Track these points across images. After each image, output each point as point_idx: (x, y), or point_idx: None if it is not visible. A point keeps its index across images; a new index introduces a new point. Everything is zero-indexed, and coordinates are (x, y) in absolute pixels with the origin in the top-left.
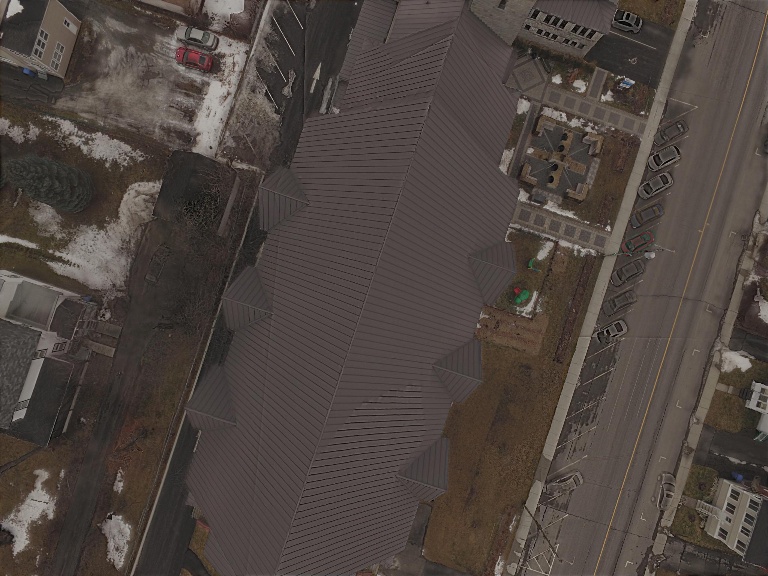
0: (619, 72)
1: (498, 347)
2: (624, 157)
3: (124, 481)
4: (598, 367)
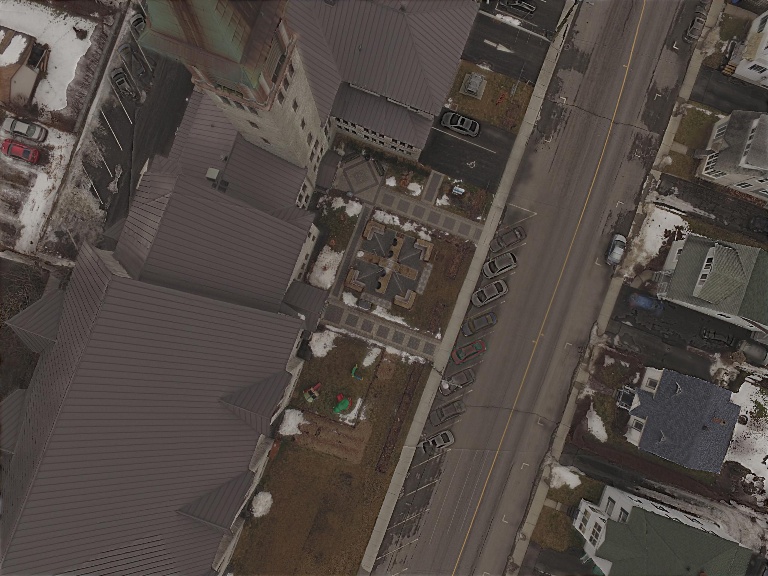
0: (456, 176)
1: (319, 454)
2: (457, 263)
3: None
4: (422, 478)
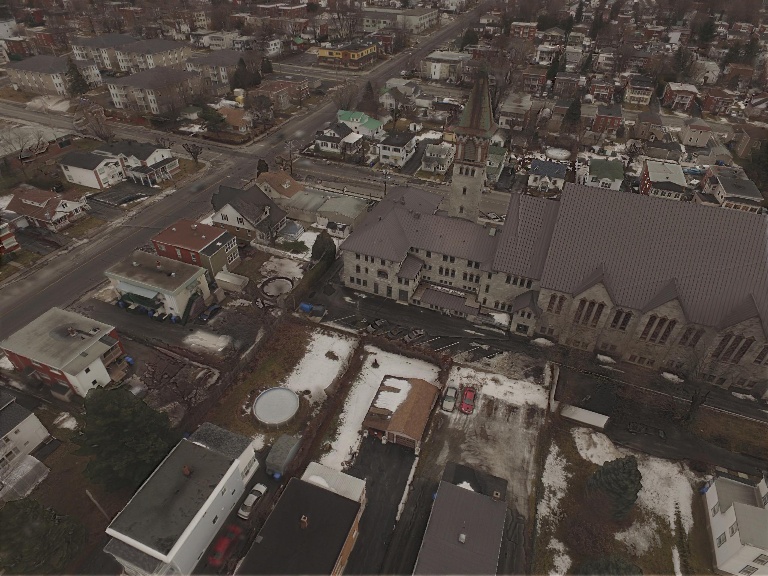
0: None
1: None
2: None
3: None
4: None
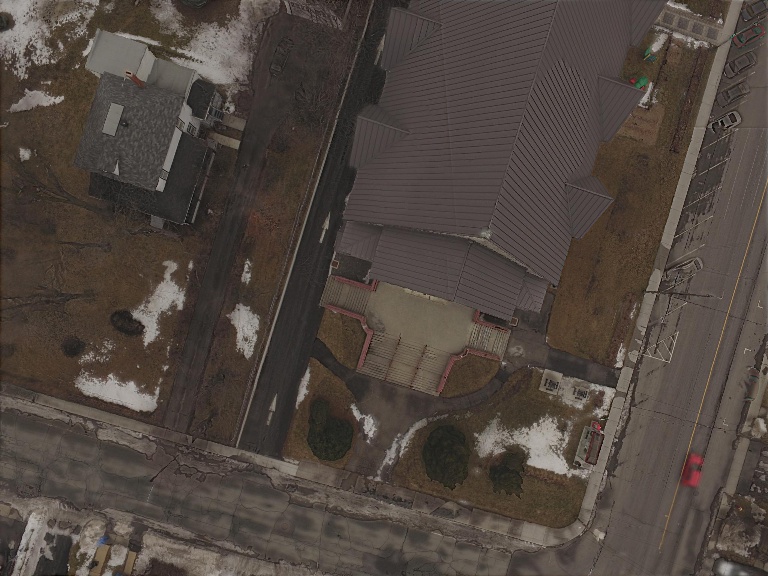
0: None
1: (616, 137)
2: None
3: (252, 272)
4: (713, 157)
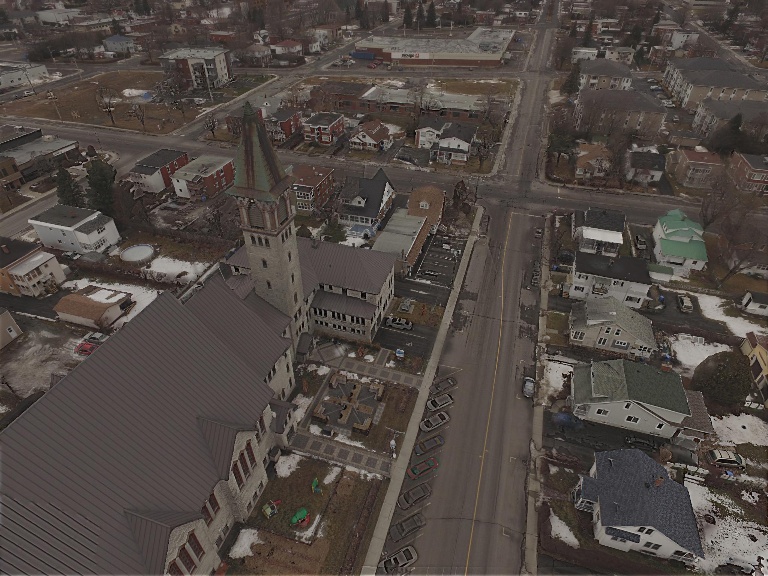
0: None
1: None
2: (405, 401)
3: None
4: None
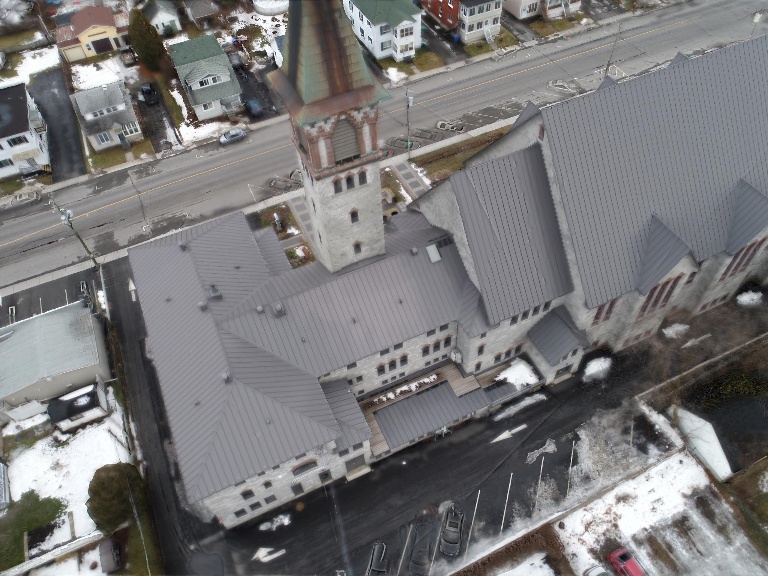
0: None
1: None
2: None
3: None
4: (479, 119)
